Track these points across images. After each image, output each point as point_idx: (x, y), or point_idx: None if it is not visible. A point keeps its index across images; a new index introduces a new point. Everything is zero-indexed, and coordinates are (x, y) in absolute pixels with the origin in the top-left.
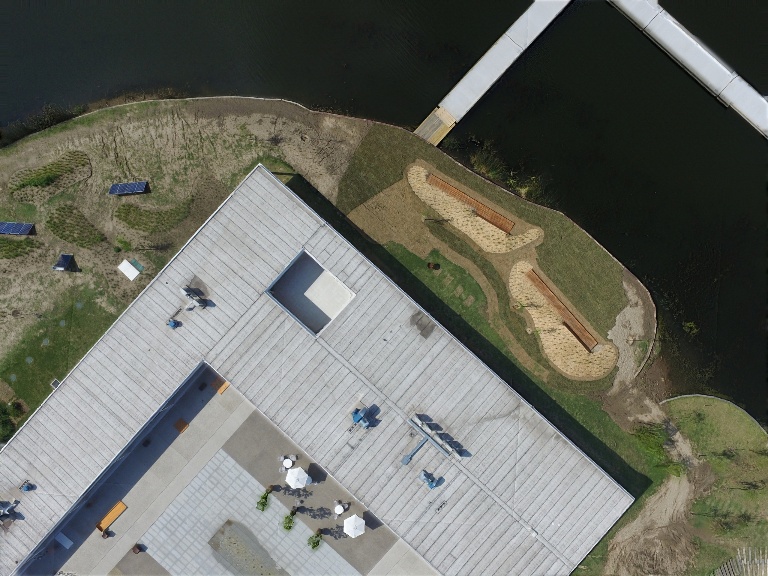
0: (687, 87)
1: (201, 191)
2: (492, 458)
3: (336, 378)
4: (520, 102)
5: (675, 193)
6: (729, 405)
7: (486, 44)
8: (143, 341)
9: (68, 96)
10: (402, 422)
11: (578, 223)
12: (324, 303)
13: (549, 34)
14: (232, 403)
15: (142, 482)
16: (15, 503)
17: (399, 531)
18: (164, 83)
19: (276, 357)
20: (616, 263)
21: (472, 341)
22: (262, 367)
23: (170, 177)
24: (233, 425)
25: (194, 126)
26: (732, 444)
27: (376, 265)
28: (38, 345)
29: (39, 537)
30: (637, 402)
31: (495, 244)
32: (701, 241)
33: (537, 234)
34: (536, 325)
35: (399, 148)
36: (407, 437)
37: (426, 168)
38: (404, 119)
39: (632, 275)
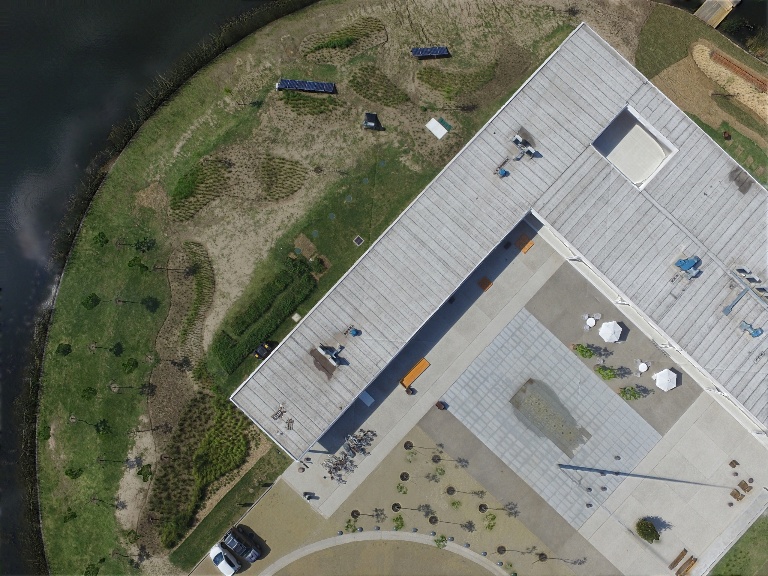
0: None
1: (504, 56)
2: None
3: (659, 230)
4: None
5: None
6: None
7: None
8: (471, 189)
9: None
10: (722, 274)
11: None
12: (626, 167)
13: None
14: (535, 263)
15: (445, 339)
16: (340, 348)
17: (720, 380)
18: None
19: (602, 208)
20: None
21: None
22: (588, 217)
23: (470, 43)
24: (536, 284)
25: None
26: None
27: None
28: (341, 202)
29: (364, 383)
30: None
31: None
32: None
33: None
34: None
35: (682, 28)
36: (727, 289)
37: (709, 47)
38: (684, 1)
39: None
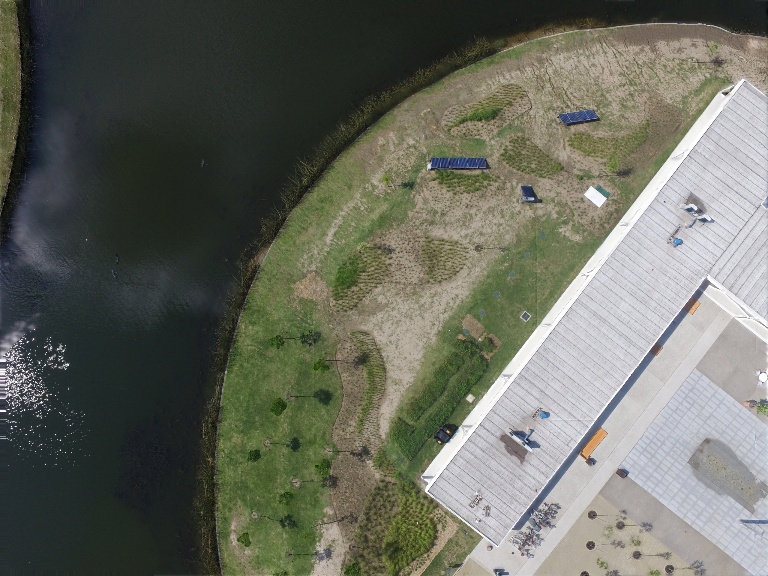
0: None
1: (655, 115)
2: None
3: None
4: None
5: None
6: None
7: None
8: (645, 261)
9: (487, 31)
10: None
11: None
12: None
13: None
14: (703, 323)
15: (620, 407)
16: None
17: None
18: (583, 13)
19: None
20: None
21: None
22: (765, 279)
23: (617, 104)
24: (706, 344)
25: (627, 53)
26: None
27: None
28: (504, 279)
29: (557, 464)
30: None
31: None
32: None
33: None
34: None
35: None
36: None
37: None
38: None
39: None
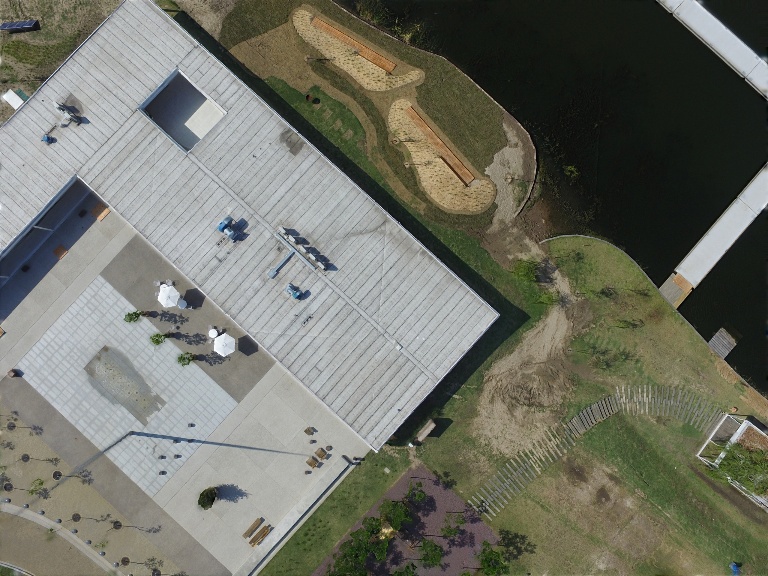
0: None
1: (88, 26)
2: (358, 272)
3: (206, 193)
4: None
5: (557, 42)
6: (608, 246)
7: None
8: (18, 157)
9: None
10: (270, 236)
11: (461, 68)
12: (204, 133)
13: None
14: (111, 230)
15: (20, 308)
16: None
17: (264, 343)
18: None
19: (147, 172)
20: (497, 106)
21: (349, 171)
22: (133, 182)
23: (59, 15)
24: (112, 252)
25: None
26: (610, 283)
27: None
28: None
29: None
30: (517, 241)
31: (375, 82)
32: (582, 88)
33: (418, 75)
34: (413, 159)
35: None
36: (274, 251)
37: (311, 12)
38: None
39: (513, 118)
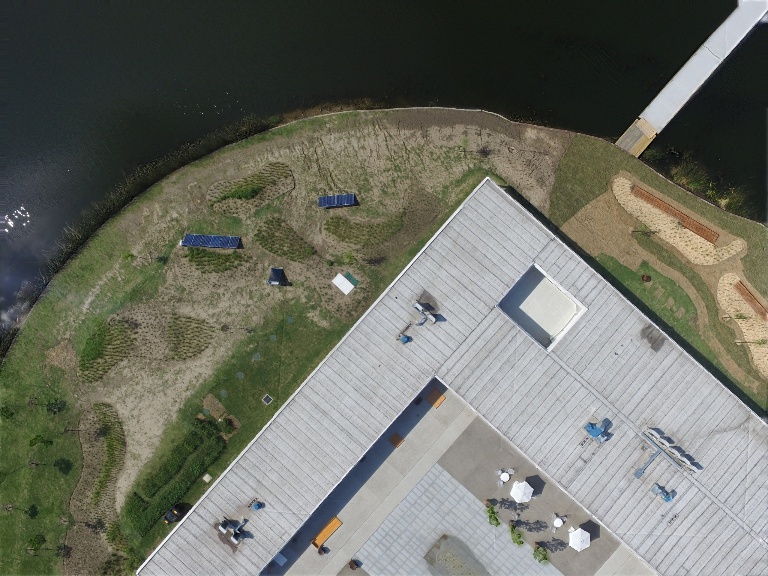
0: None
1: (413, 204)
2: (723, 470)
3: (568, 392)
4: (717, 113)
5: None
6: None
7: (685, 55)
8: (373, 357)
9: (263, 106)
10: (634, 436)
11: None
12: (539, 316)
13: (744, 45)
14: (447, 417)
15: (357, 498)
16: (244, 521)
17: (632, 544)
18: (361, 93)
19: (508, 372)
20: None
21: None
22: (494, 382)
23: (378, 189)
24: (449, 439)
25: (397, 137)
26: None
27: None
28: (248, 360)
29: (269, 556)
30: None
31: (703, 256)
32: None
33: (741, 245)
34: (746, 336)
35: (602, 160)
36: (639, 450)
37: (630, 180)
38: (605, 130)
39: None
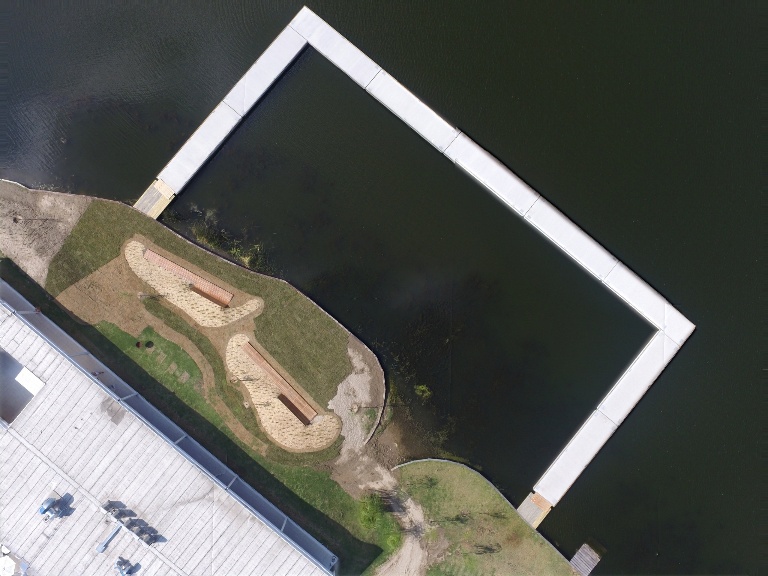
0: (415, 144)
1: None
2: (188, 542)
3: (29, 468)
4: (242, 169)
5: (404, 254)
6: (463, 468)
7: (203, 113)
8: None
9: None
10: (96, 509)
11: (303, 290)
12: (35, 387)
13: (271, 98)
14: None
15: None
16: None
17: None
18: None
19: None
20: (342, 329)
21: (185, 419)
22: None
23: None
24: None
25: None
26: (465, 508)
27: (86, 346)
28: None
29: None
30: (368, 469)
31: (210, 318)
32: (432, 302)
33: (257, 305)
34: (253, 399)
35: (118, 223)
36: (102, 524)
37: (143, 243)
38: (123, 193)
39: (359, 341)
